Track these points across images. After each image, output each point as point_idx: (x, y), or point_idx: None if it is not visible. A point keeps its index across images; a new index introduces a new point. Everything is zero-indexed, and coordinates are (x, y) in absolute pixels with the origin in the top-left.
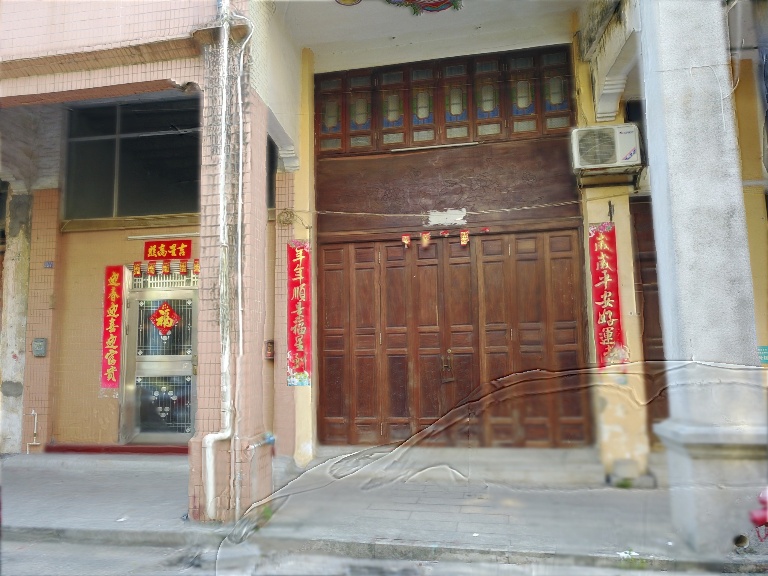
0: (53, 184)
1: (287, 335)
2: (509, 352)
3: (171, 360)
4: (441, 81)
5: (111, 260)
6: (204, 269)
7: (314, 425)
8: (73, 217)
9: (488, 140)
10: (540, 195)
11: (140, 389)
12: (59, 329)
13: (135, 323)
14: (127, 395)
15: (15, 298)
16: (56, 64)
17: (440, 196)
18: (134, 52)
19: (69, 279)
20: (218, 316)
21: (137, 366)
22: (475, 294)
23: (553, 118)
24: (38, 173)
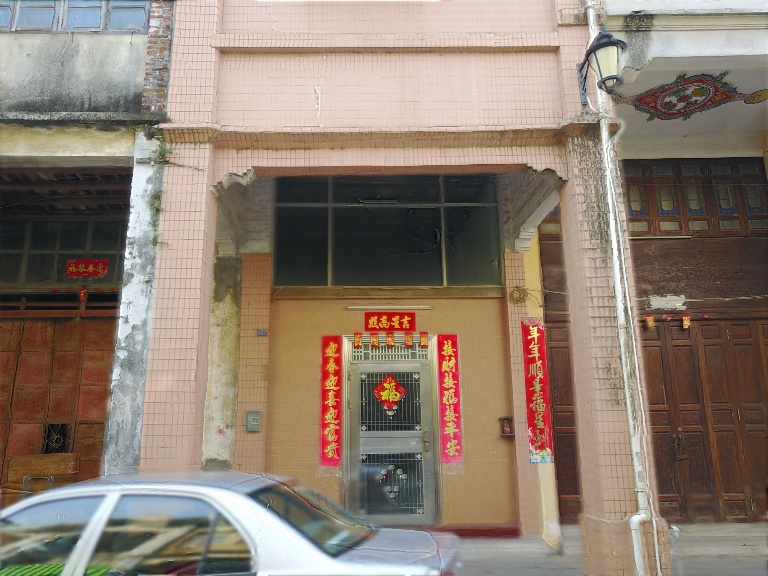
0: (264, 248)
1: (527, 412)
2: (737, 431)
3: (400, 436)
4: (650, 179)
5: (328, 330)
6: (597, 349)
7: (558, 504)
8: (284, 283)
9: (701, 235)
10: (750, 287)
11: (366, 467)
12: (272, 401)
13: (358, 396)
14: (352, 474)
15: (222, 367)
16: (411, 139)
17: (658, 283)
18: (495, 136)
19: (280, 348)
20: (617, 395)
21: (362, 442)
22: (698, 375)
23: (753, 220)
24: (246, 236)
